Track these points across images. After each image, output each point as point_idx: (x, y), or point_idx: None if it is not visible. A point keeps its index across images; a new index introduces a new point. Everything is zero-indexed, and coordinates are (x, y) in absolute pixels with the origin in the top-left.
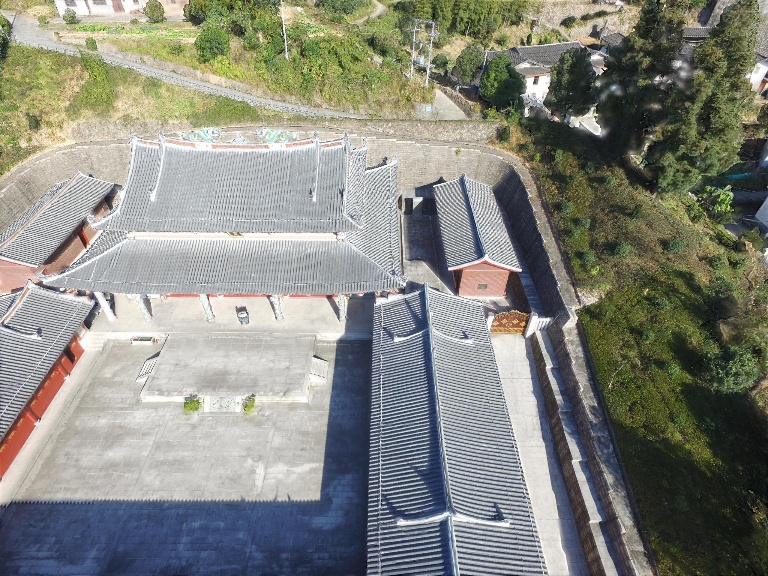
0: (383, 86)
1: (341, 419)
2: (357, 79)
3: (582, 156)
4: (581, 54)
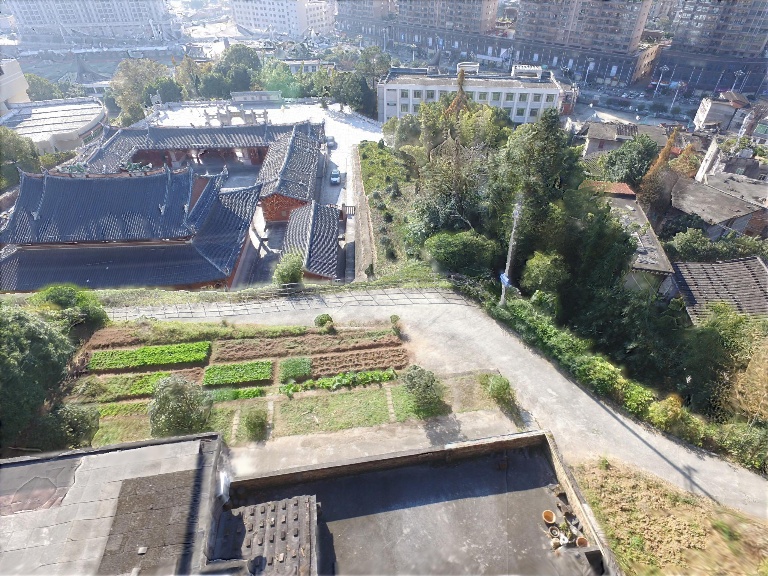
0: None
1: None
2: None
3: None
4: None
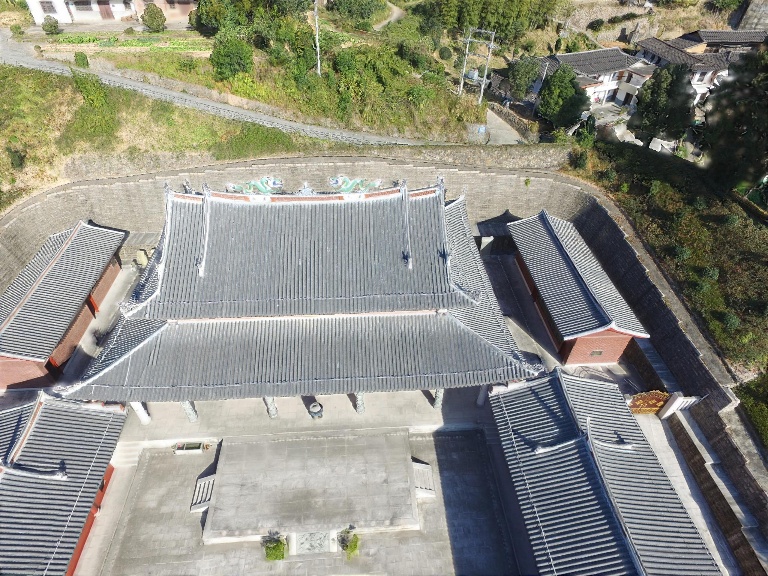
0: (430, 105)
1: (468, 552)
2: (401, 97)
3: (684, 188)
4: (681, 70)
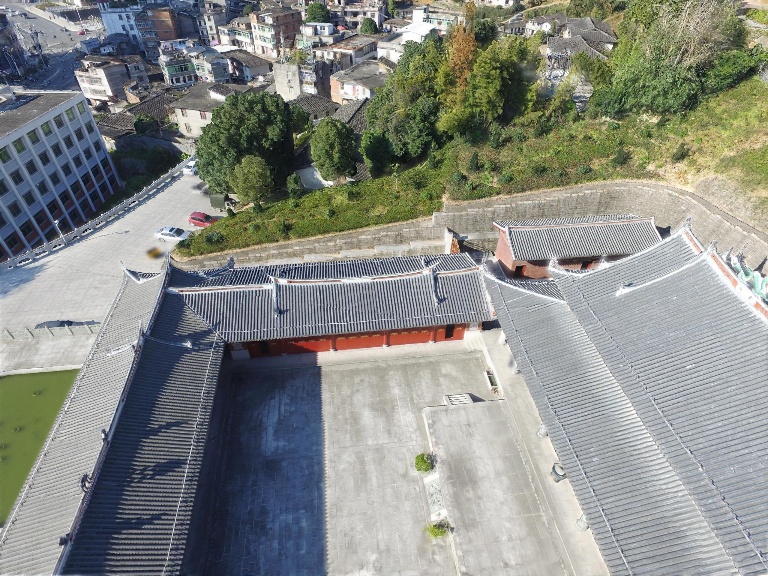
0: None
1: None
2: None
3: None
4: None
